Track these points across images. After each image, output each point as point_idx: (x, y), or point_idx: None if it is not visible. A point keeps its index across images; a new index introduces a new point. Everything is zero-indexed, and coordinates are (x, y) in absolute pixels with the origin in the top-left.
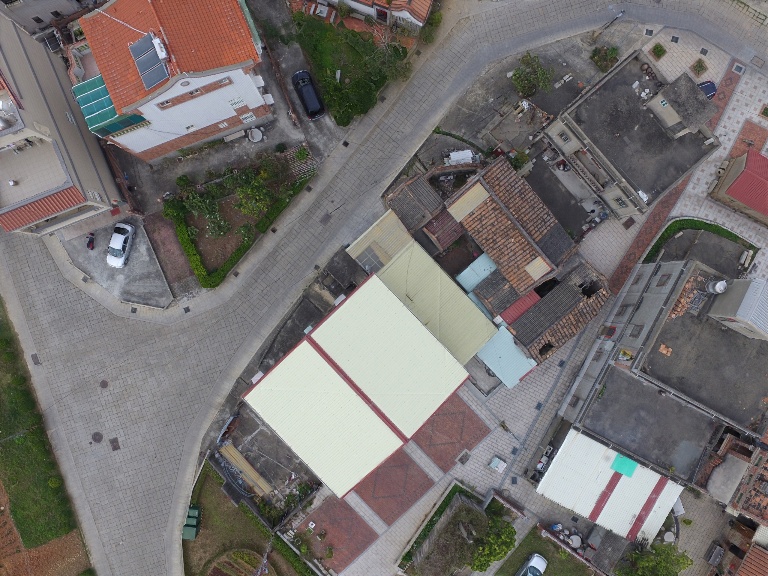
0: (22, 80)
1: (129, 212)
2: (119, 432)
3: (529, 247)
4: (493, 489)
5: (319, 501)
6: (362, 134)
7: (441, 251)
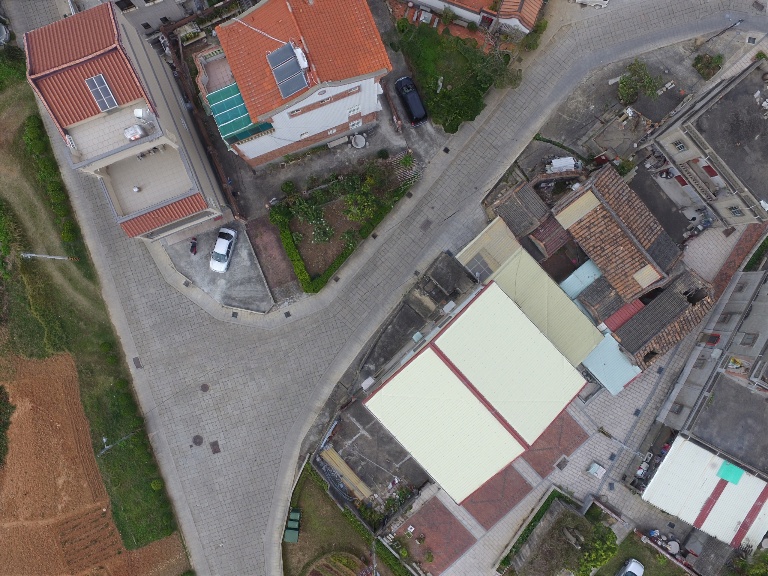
0: (152, 88)
1: (237, 218)
2: (219, 435)
3: (639, 255)
4: (591, 495)
5: (418, 505)
6: (463, 140)
7: (547, 258)
